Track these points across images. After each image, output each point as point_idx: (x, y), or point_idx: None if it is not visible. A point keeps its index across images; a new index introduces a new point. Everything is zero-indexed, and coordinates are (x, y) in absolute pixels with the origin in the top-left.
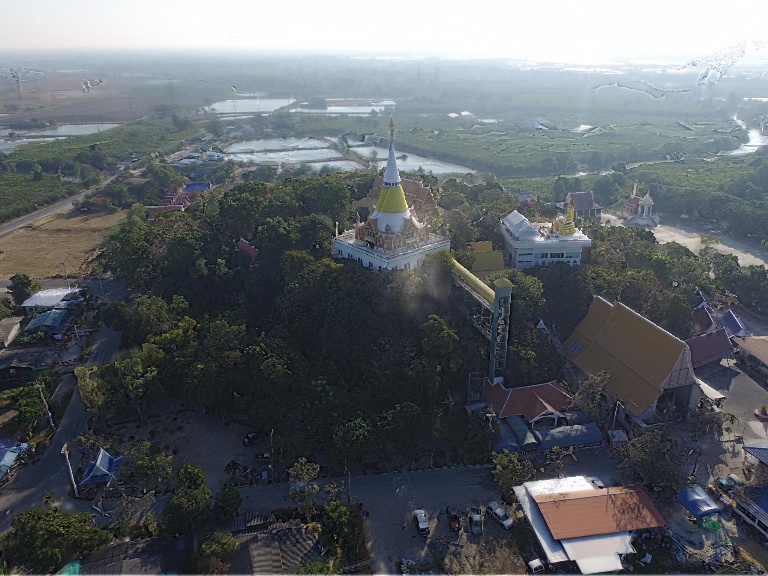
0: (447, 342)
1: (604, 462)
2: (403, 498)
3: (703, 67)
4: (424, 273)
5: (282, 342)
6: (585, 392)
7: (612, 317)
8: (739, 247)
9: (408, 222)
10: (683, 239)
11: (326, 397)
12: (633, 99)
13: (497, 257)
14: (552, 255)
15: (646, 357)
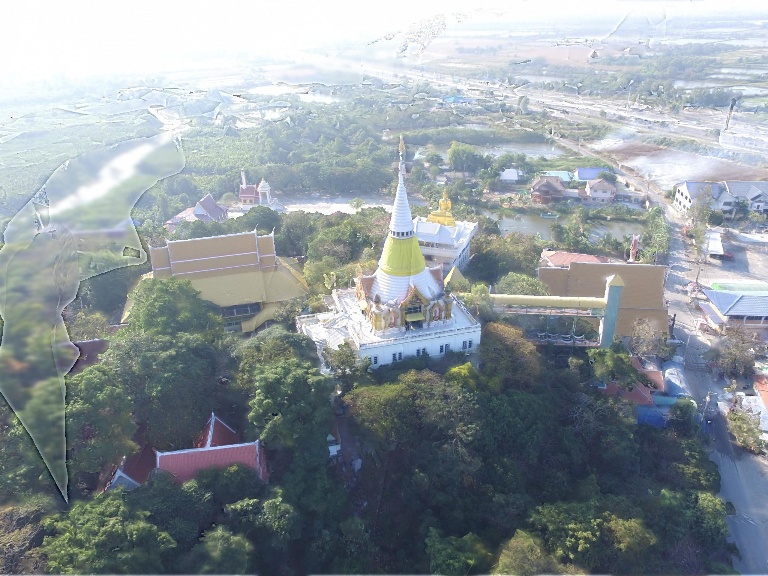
0: (630, 366)
1: (698, 383)
2: (765, 522)
3: (400, 40)
4: (486, 323)
5: (550, 506)
6: (650, 342)
7: (575, 278)
8: (368, 202)
9: (441, 273)
10: (328, 211)
11: (676, 505)
12: (322, 80)
13: (459, 274)
14: (462, 252)
15: (633, 293)
